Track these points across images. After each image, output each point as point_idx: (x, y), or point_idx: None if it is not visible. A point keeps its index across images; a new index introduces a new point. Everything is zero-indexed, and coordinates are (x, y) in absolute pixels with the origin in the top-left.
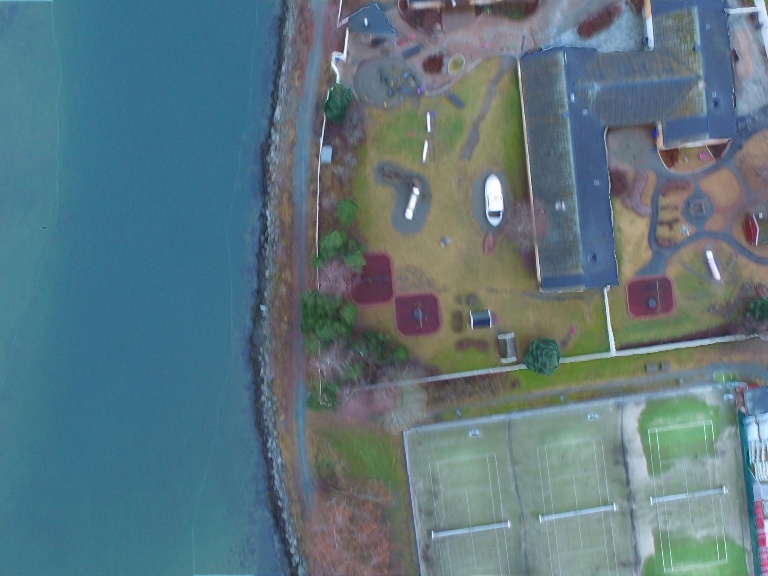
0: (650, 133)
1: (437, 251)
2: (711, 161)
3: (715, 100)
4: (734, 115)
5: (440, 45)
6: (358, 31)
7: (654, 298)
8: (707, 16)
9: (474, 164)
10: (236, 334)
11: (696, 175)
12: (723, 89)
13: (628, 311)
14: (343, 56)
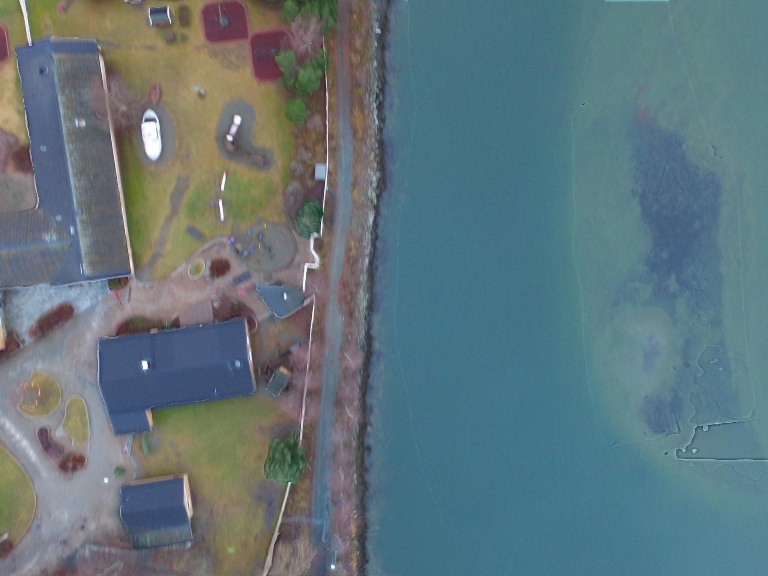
0: None
1: (209, 86)
2: None
3: None
4: None
5: (214, 287)
6: (294, 290)
7: None
8: None
9: (175, 173)
10: (404, 8)
11: None
12: None
13: (7, 30)
14: (308, 266)
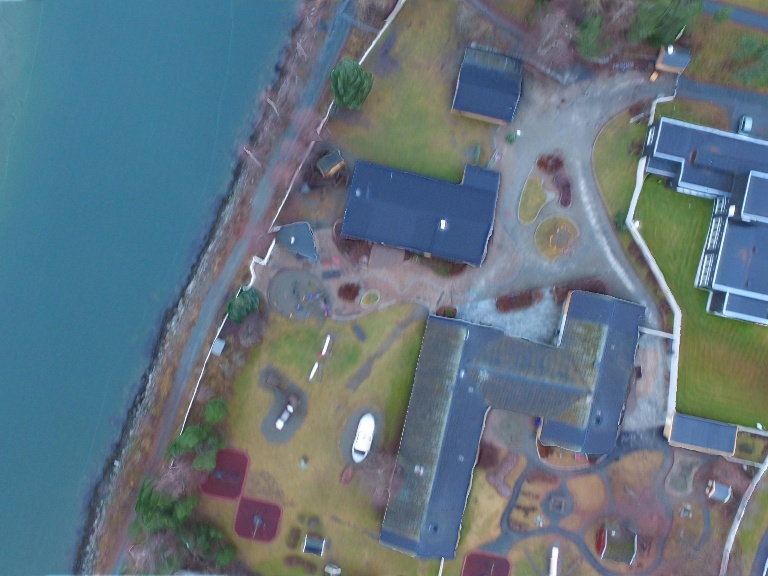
0: (534, 420)
1: (296, 466)
2: (585, 463)
3: (598, 417)
4: (615, 433)
5: (361, 276)
6: (284, 244)
7: (488, 575)
8: (616, 336)
9: (357, 396)
10: (85, 477)
11: (566, 472)
12: (611, 407)
13: None
14: (263, 262)
